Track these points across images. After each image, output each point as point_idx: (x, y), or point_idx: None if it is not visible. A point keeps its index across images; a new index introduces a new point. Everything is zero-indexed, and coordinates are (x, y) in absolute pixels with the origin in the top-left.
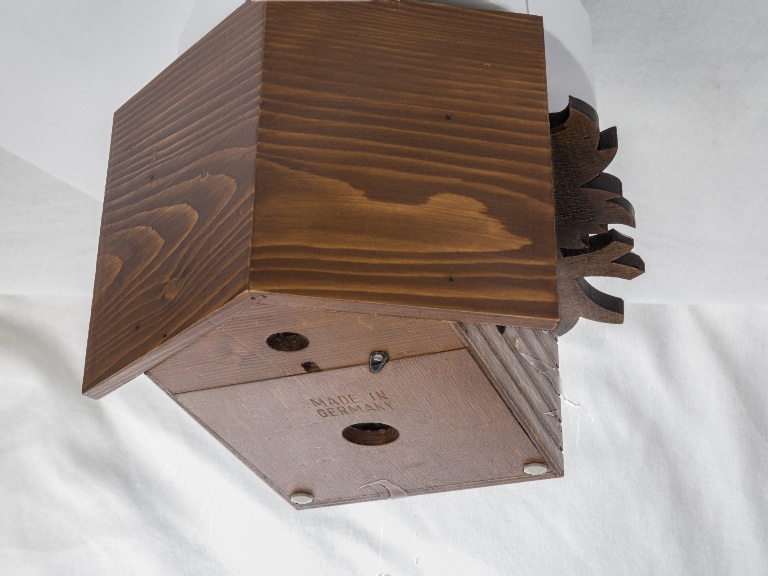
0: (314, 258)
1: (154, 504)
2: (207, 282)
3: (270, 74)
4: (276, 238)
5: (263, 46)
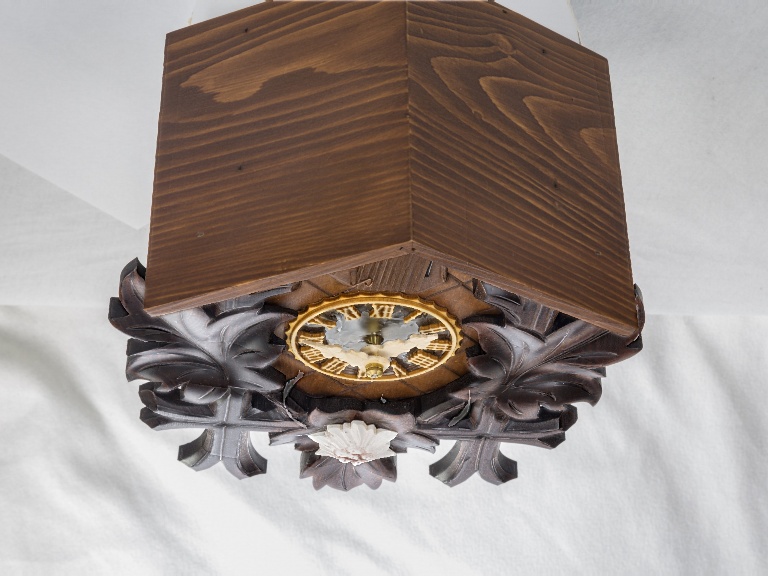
0: (354, 2)
1: None
2: (457, 8)
3: (401, 146)
4: (386, 5)
5: (410, 172)
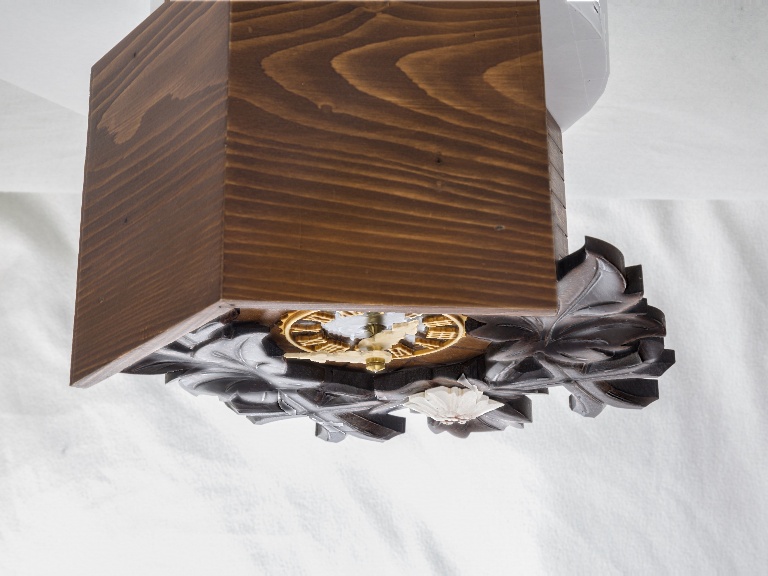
0: (198, 7)
1: (605, 13)
2: None
3: (219, 184)
4: (217, 7)
5: (224, 216)
